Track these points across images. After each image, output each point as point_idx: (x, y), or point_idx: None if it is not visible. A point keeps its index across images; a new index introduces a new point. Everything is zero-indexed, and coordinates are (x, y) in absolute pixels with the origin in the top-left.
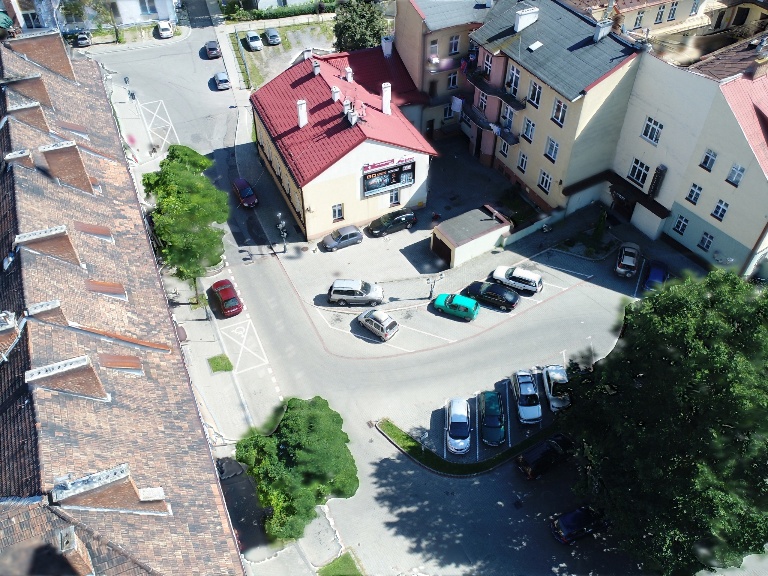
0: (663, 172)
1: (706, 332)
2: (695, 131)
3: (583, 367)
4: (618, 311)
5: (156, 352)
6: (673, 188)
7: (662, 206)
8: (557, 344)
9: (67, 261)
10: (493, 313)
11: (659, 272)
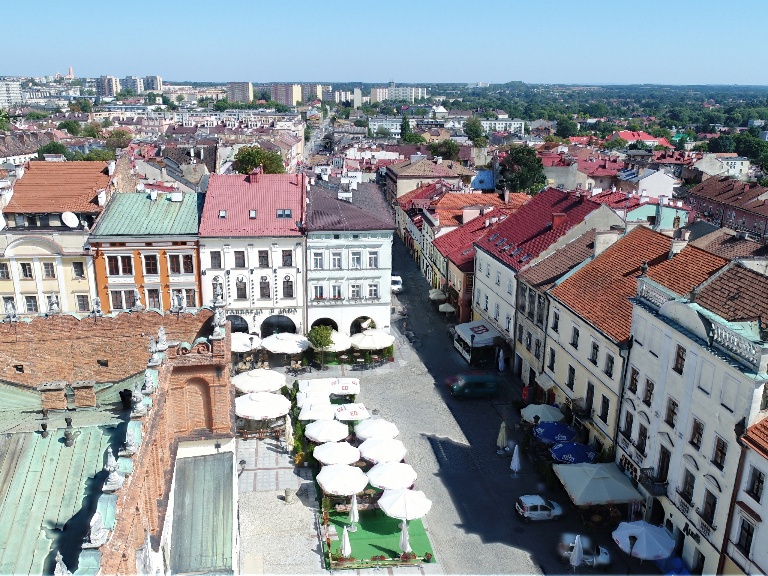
0: None
1: None
2: None
3: None
4: None
5: (3, 153)
6: None
7: None
8: None
9: (4, 143)
10: None
11: None
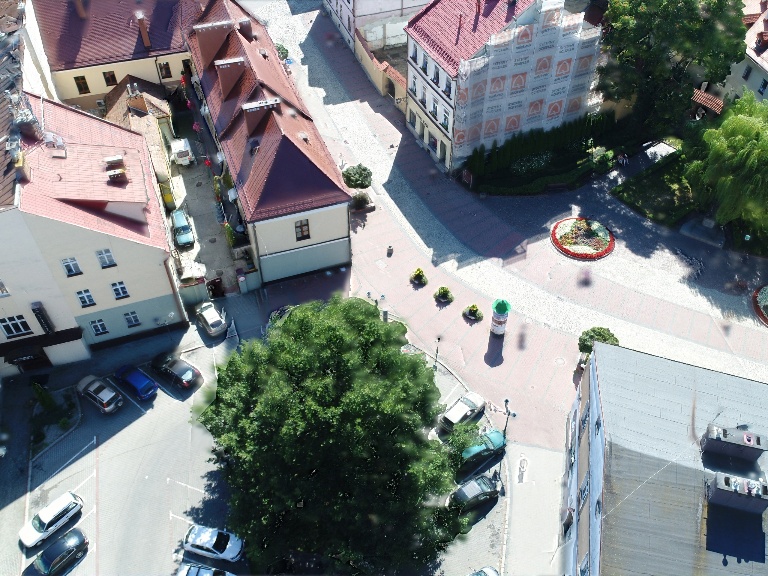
0: (41, 308)
1: (326, 399)
2: (35, 257)
3: (199, 504)
4: (153, 436)
5: None
6: (62, 310)
7: (68, 330)
8: (159, 517)
9: None
10: (78, 571)
11: (136, 376)
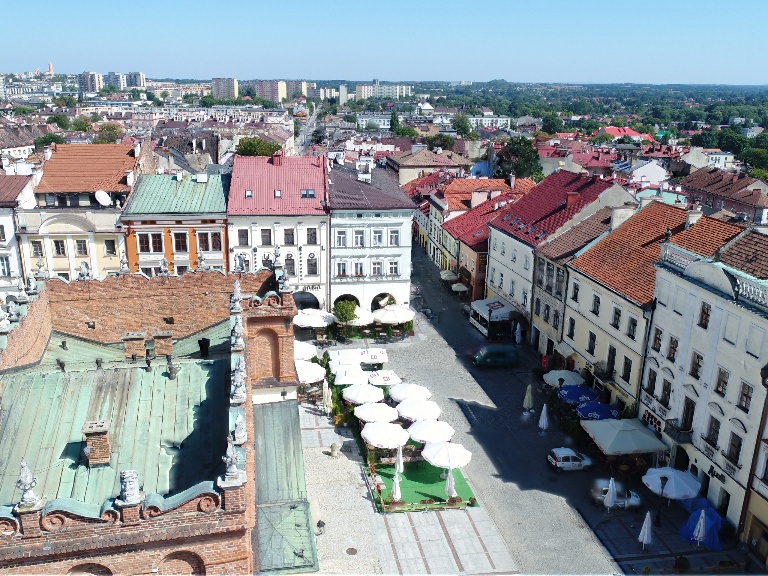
0: None
1: None
2: None
3: None
4: None
5: None
6: None
7: None
8: None
9: None
10: None
11: None
